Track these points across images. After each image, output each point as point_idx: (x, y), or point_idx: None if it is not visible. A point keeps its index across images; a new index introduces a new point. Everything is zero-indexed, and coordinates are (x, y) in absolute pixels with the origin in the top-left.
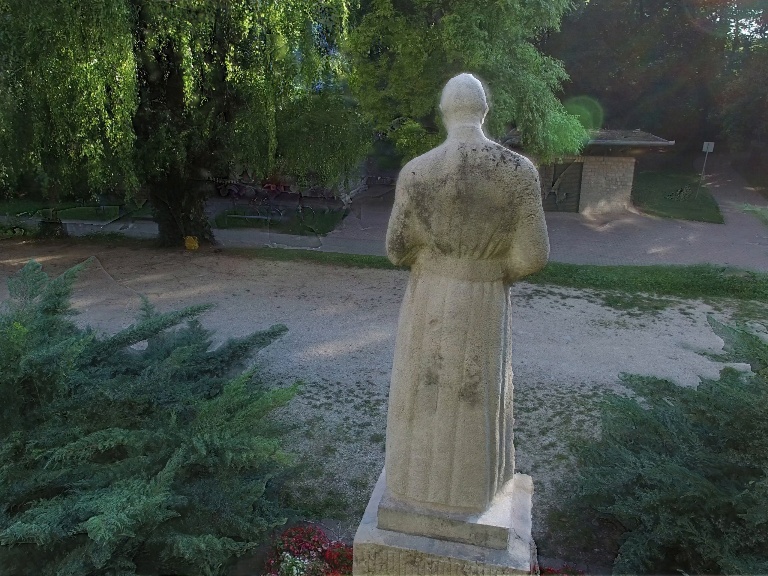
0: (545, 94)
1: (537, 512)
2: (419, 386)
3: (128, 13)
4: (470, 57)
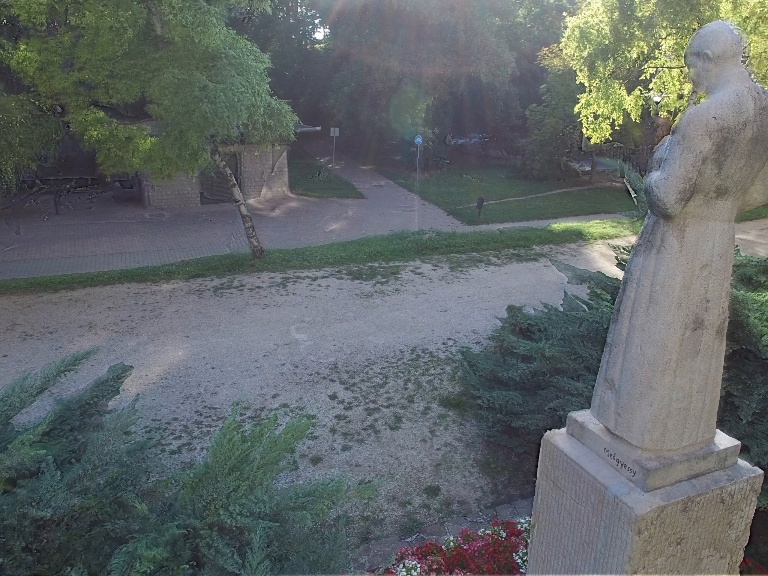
0: (262, 78)
1: (469, 469)
2: (686, 335)
3: None
4: (202, 35)
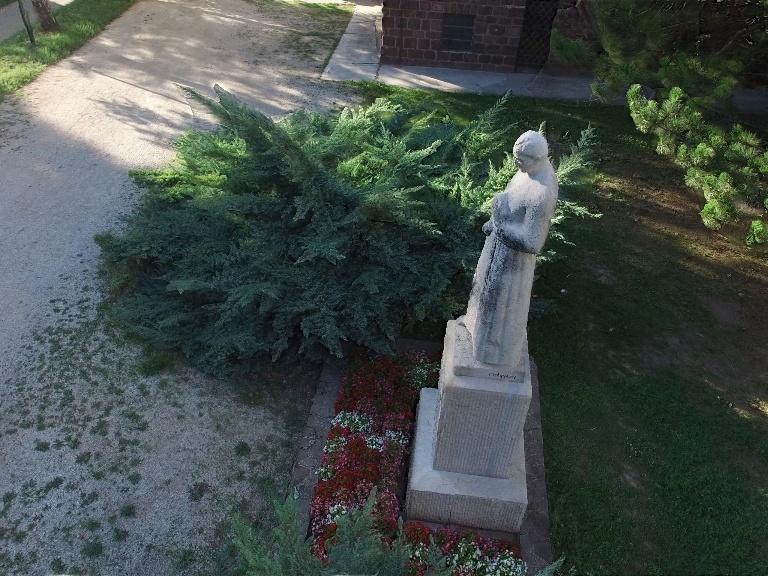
0: None
1: (241, 411)
2: None
3: None
4: None
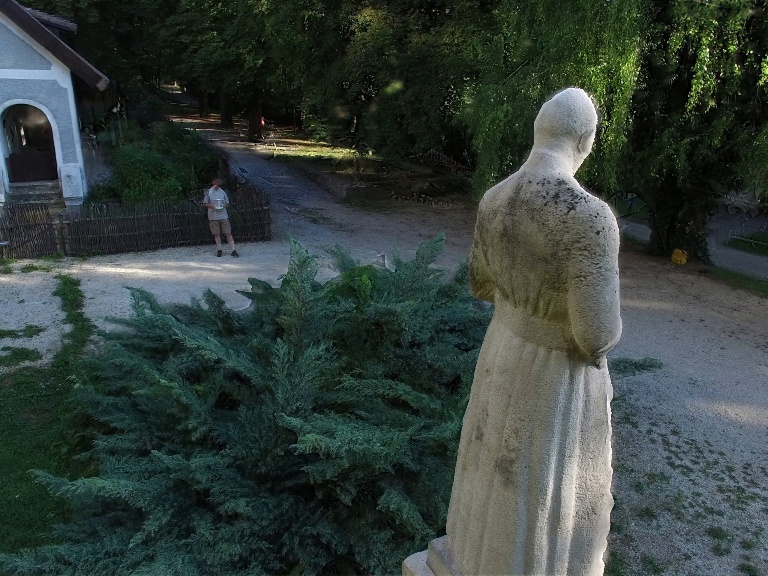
0: None
1: None
2: (473, 436)
3: (639, 16)
4: None
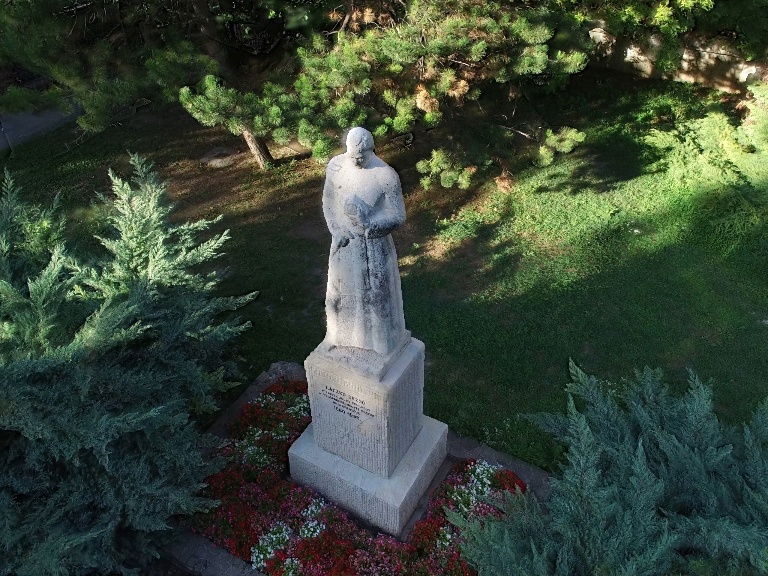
0: None
1: None
2: None
3: None
4: None
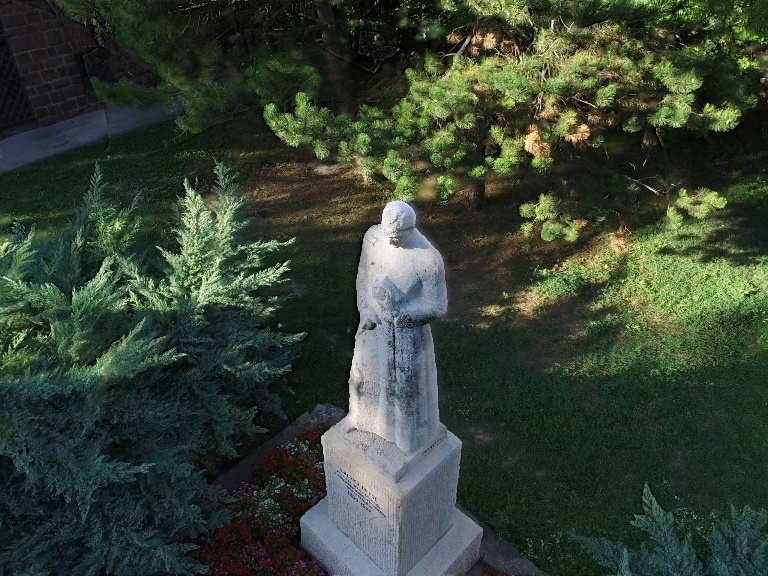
0: None
1: None
2: None
3: None
4: None
